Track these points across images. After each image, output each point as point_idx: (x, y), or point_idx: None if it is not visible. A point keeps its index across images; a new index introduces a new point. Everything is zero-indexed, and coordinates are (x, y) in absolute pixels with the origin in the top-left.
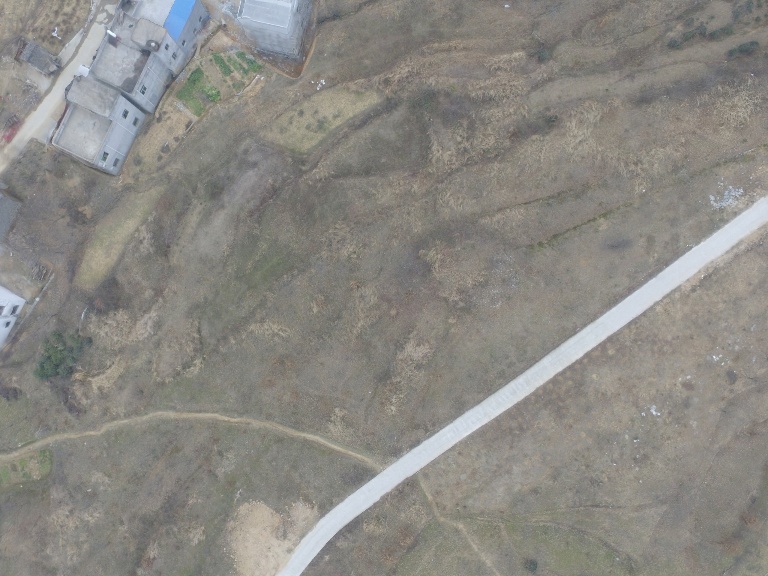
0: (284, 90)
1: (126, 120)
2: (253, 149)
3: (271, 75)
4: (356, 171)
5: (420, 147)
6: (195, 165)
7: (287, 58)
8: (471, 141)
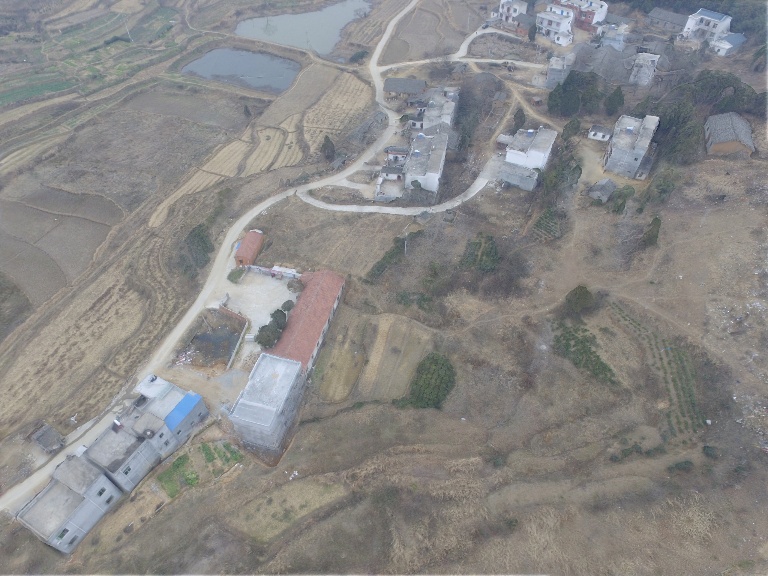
0: (258, 478)
1: (100, 497)
2: (215, 534)
3: (249, 464)
4: (314, 566)
5: (383, 544)
6: (152, 548)
7: (268, 449)
8: (433, 541)
